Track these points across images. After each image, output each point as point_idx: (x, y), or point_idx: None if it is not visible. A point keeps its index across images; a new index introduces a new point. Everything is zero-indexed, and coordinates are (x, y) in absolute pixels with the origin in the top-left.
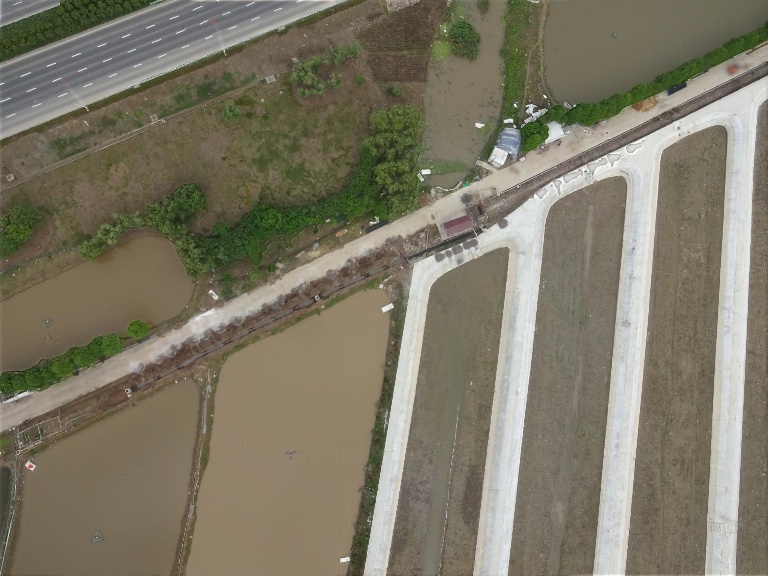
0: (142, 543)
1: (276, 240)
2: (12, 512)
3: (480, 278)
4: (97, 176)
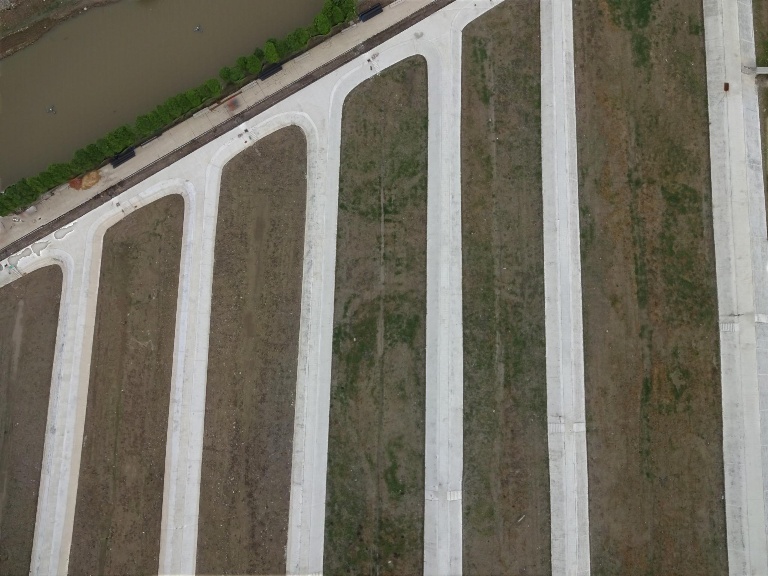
0: None
1: None
2: None
3: None
4: None
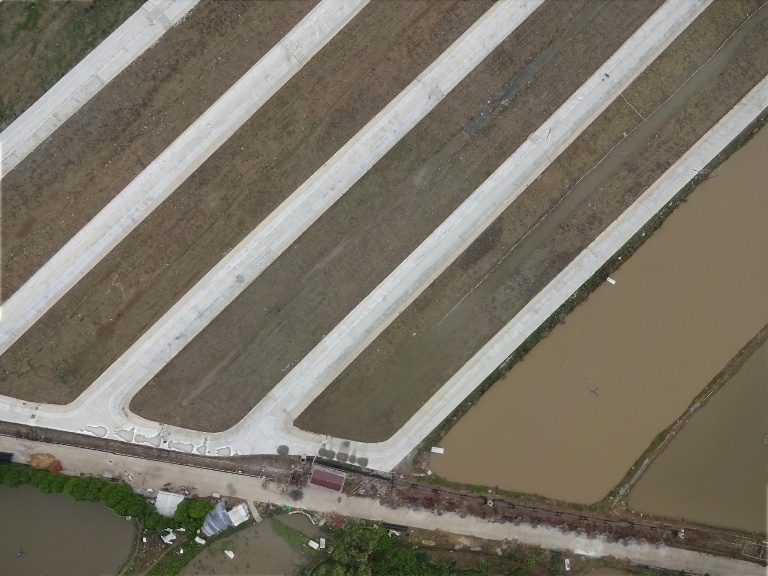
0: (741, 410)
1: None
2: None
3: (339, 416)
4: None
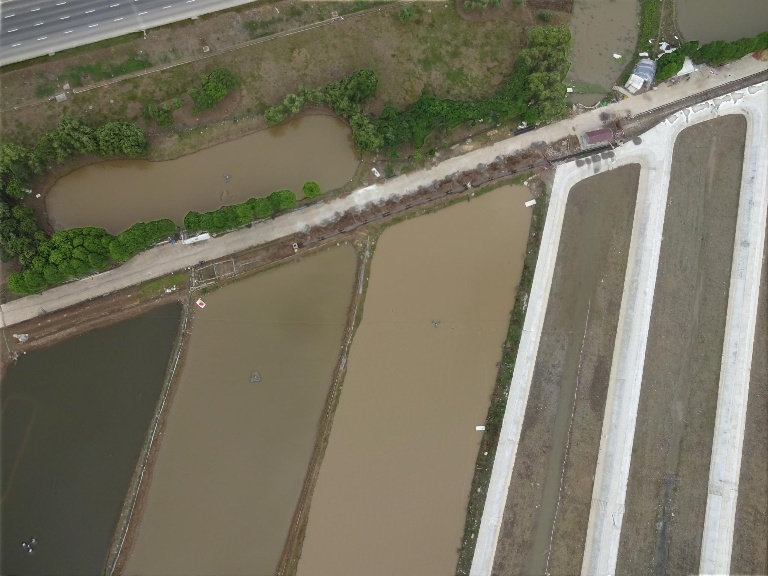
0: (295, 388)
1: (435, 130)
2: (181, 343)
3: (614, 188)
4: (282, 57)
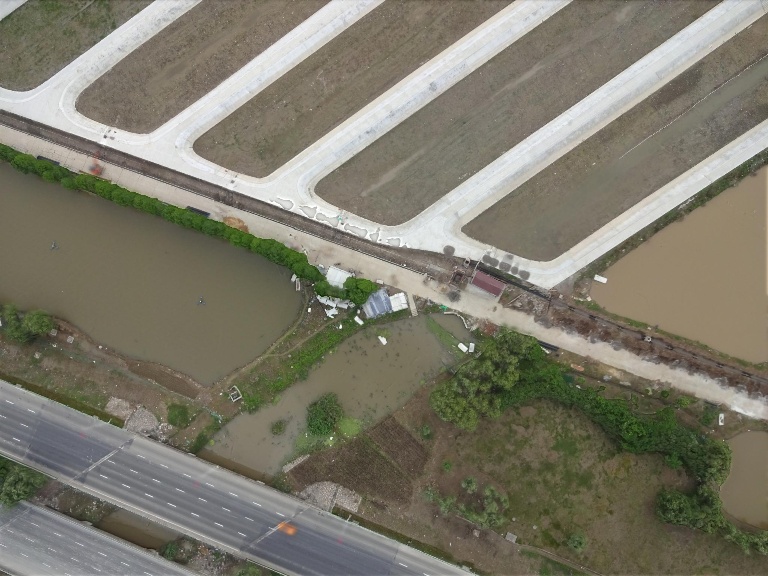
0: None
1: None
2: None
3: (506, 230)
4: None
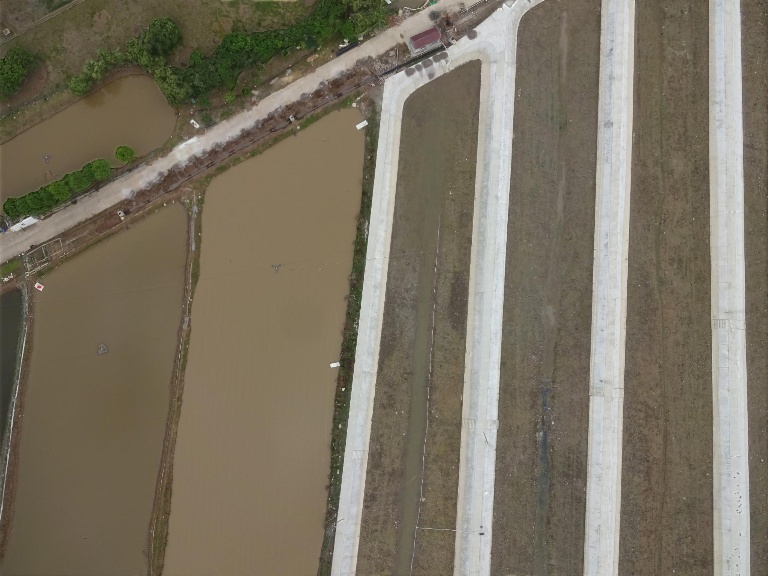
0: (143, 354)
1: (250, 68)
2: (25, 327)
3: (453, 91)
4: (82, 24)
